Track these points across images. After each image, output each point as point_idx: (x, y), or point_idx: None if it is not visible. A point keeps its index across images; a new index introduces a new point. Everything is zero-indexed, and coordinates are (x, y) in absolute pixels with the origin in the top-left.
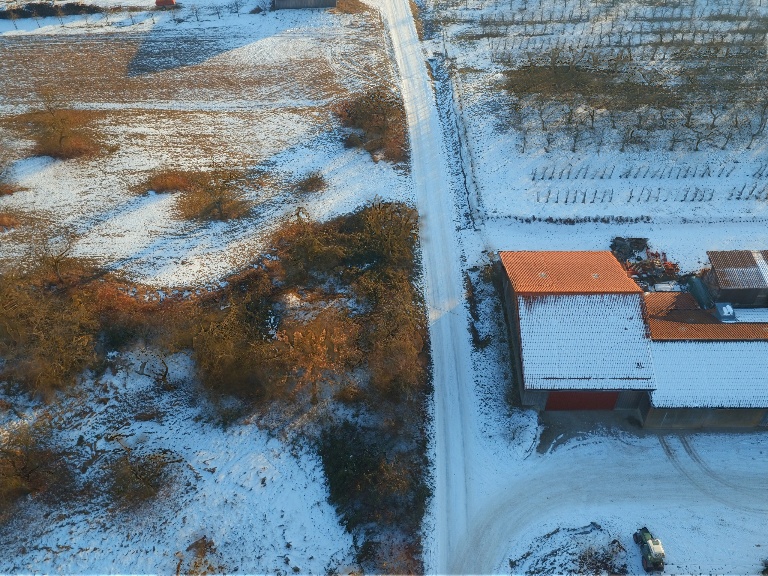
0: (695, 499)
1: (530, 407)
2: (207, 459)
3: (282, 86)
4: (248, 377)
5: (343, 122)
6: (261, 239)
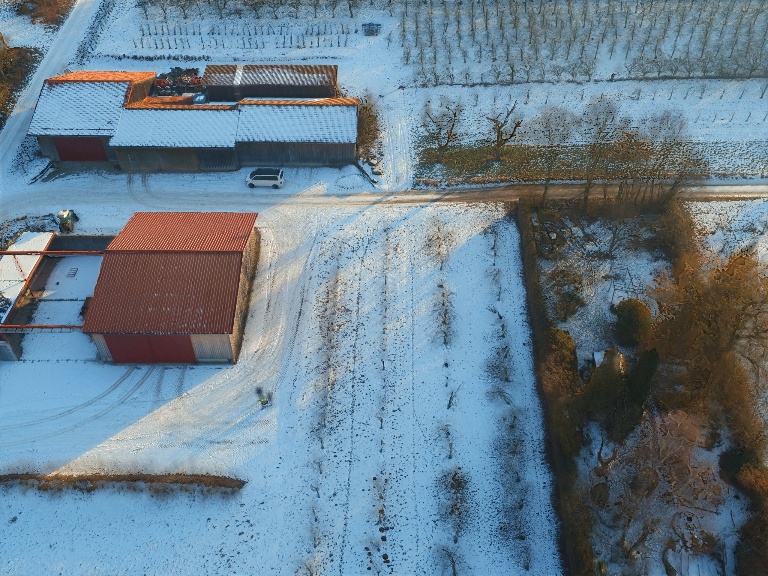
0: (126, 203)
1: (47, 156)
2: None
3: None
4: None
5: None
6: None
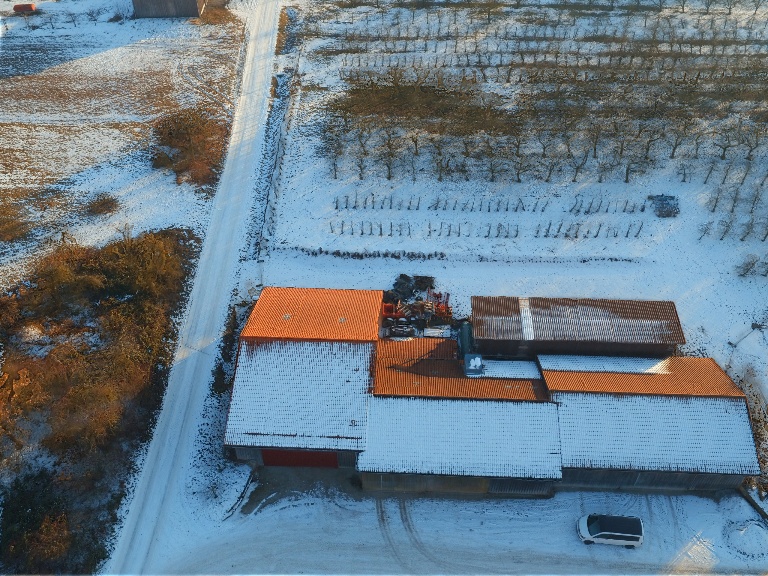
0: (390, 574)
1: (245, 462)
2: None
3: (114, 99)
4: None
5: (161, 140)
6: (28, 264)
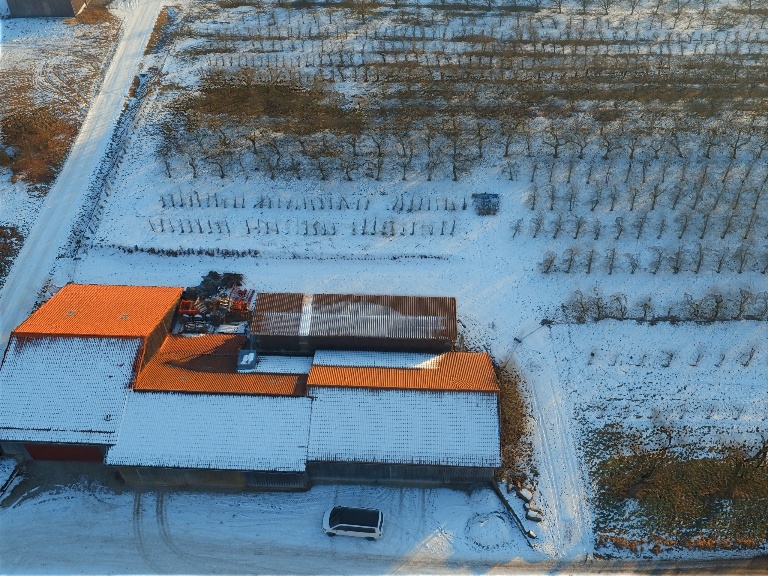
0: (130, 566)
1: (12, 456)
2: None
3: None
4: None
5: (7, 139)
6: None
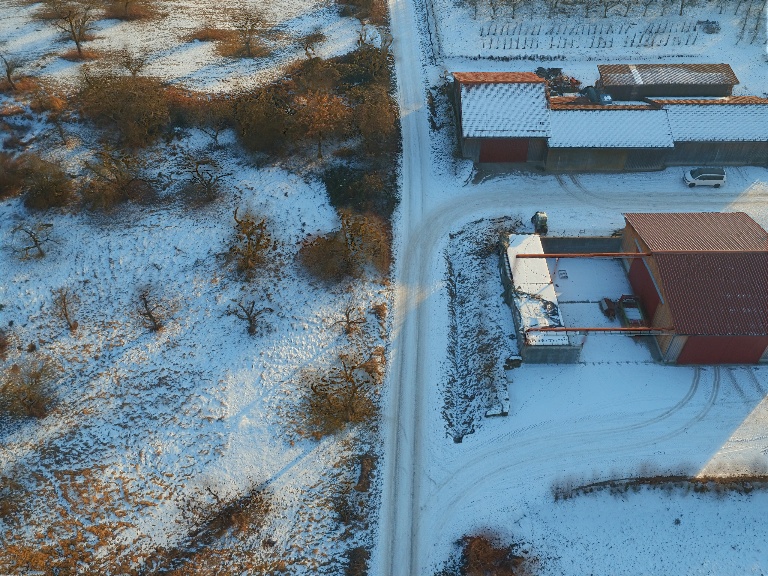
0: (575, 204)
1: (468, 158)
2: (247, 183)
3: None
4: (274, 135)
5: (339, 1)
6: (279, 69)
